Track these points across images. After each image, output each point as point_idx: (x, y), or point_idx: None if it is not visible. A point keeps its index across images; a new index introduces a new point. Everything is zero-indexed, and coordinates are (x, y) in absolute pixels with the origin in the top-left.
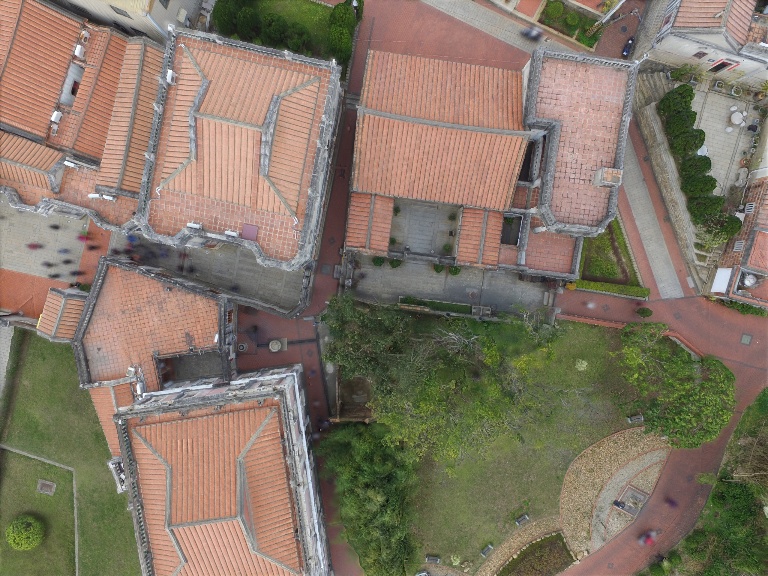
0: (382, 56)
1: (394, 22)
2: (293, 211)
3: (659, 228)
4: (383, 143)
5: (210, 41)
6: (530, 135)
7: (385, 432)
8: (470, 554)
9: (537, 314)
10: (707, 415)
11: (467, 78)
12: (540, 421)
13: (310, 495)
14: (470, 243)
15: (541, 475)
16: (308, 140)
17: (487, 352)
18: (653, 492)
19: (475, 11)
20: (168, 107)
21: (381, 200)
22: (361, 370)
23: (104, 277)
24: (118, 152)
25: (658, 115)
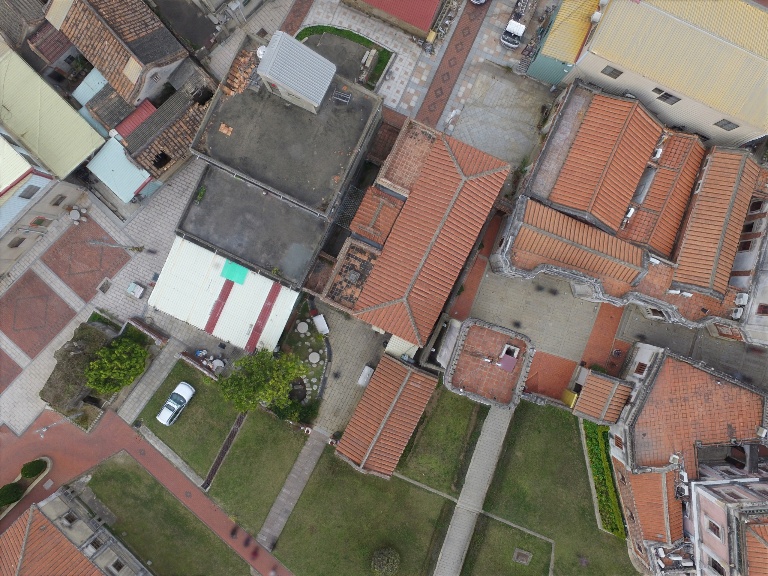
0: None
1: None
2: None
3: None
4: None
5: None
6: None
7: None
8: None
9: None
10: None
11: None
12: None
13: None
14: None
15: None
16: None
17: None
18: None
19: None
20: None
21: None
22: None
23: None
24: (704, 253)
25: None
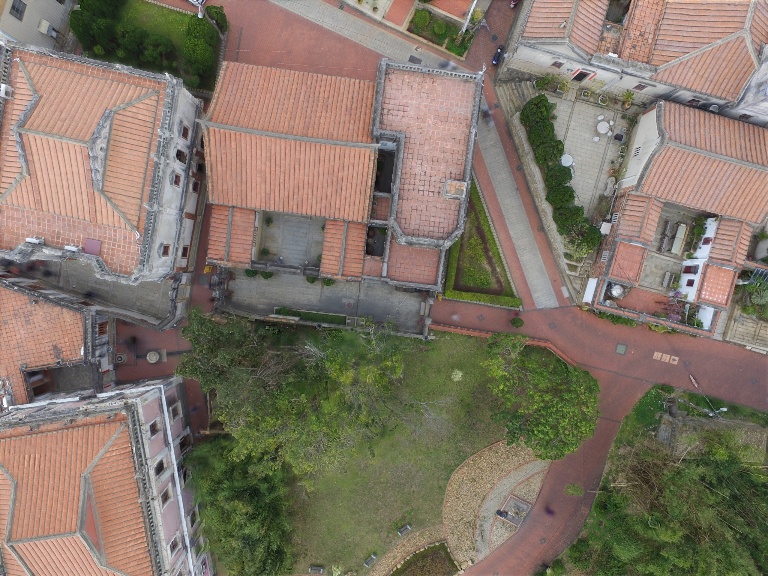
0: (236, 67)
1: (262, 32)
2: (133, 225)
3: (533, 238)
4: (233, 156)
5: (46, 55)
6: (375, 147)
7: None
8: (354, 564)
9: None
10: (564, 427)
11: (322, 89)
12: (420, 431)
13: (180, 507)
14: (332, 255)
15: (423, 485)
16: (148, 154)
17: (331, 366)
18: (536, 501)
19: (344, 20)
20: (6, 121)
21: (241, 212)
22: (211, 384)
23: None
24: None
25: (522, 125)
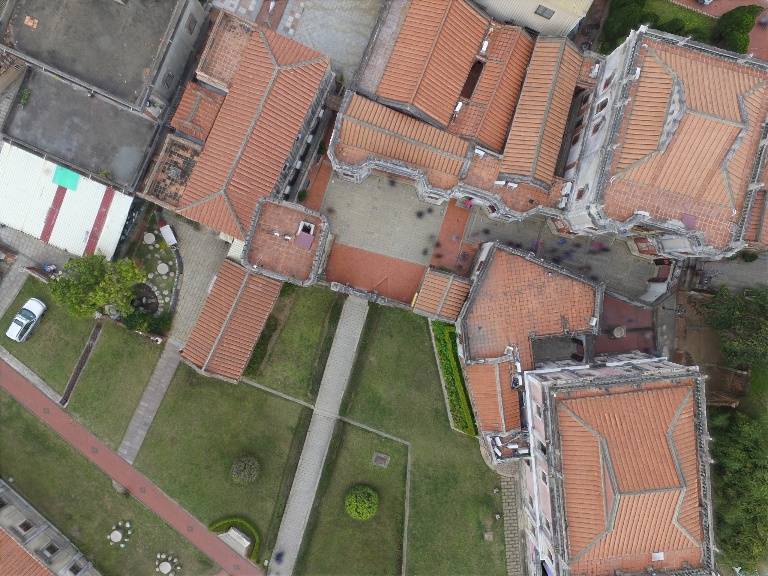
0: None
1: (762, 31)
2: (735, 203)
3: None
4: None
5: (669, 42)
6: None
7: (761, 416)
8: None
9: None
10: None
11: None
12: None
13: None
14: None
15: None
16: (752, 138)
17: None
18: None
19: None
20: None
21: None
22: None
23: None
24: (527, 142)
25: None
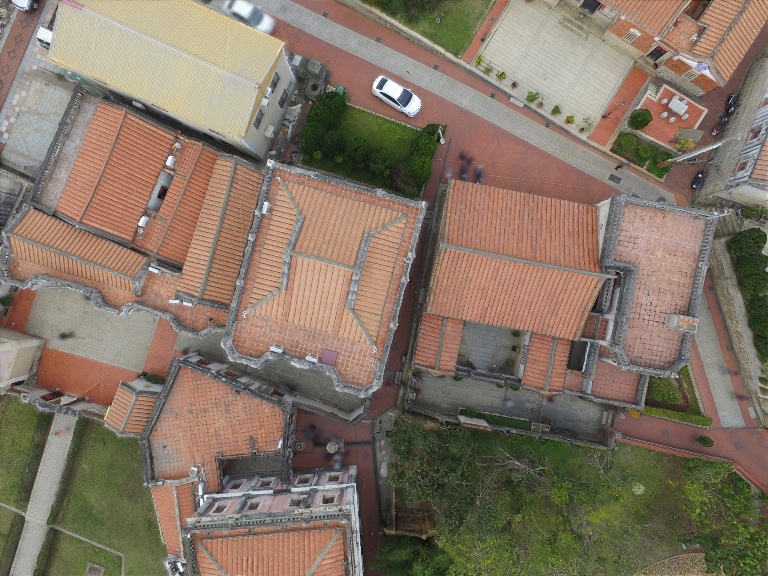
0: (462, 186)
1: (470, 144)
2: (373, 341)
3: (722, 357)
4: (461, 273)
5: (305, 175)
6: (607, 277)
7: (443, 553)
8: None
9: (607, 454)
10: None
11: (544, 211)
12: None
13: None
14: (537, 368)
15: None
16: (392, 273)
17: (557, 492)
18: None
19: (549, 137)
20: (260, 235)
21: (452, 322)
22: (428, 497)
23: (175, 377)
24: (201, 262)
25: (728, 252)
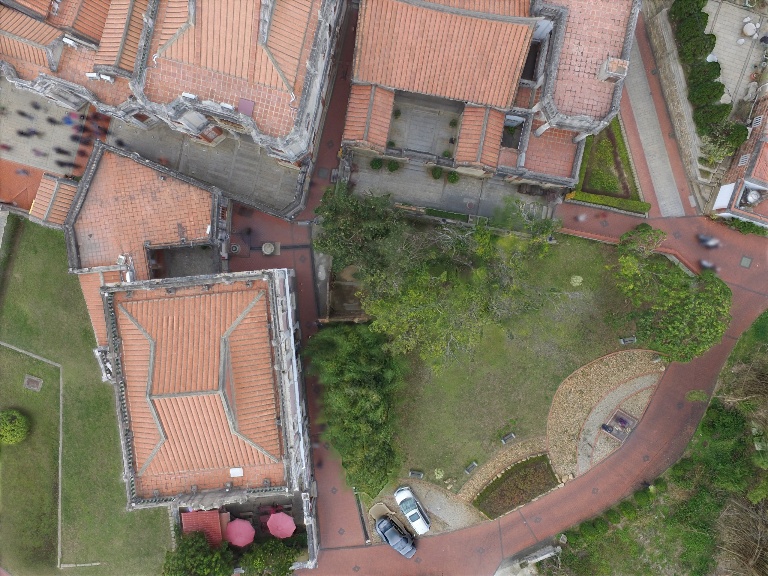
0: None
1: None
2: (290, 86)
3: (663, 144)
4: (386, 28)
5: None
6: (536, 22)
7: None
8: (454, 471)
9: (533, 207)
10: (701, 324)
11: None
12: (532, 339)
13: (295, 394)
14: (470, 142)
15: (530, 394)
16: (309, 14)
17: (480, 240)
18: (642, 418)
19: None
20: None
21: (381, 93)
22: (352, 257)
23: (98, 162)
24: (117, 30)
25: (669, 22)
